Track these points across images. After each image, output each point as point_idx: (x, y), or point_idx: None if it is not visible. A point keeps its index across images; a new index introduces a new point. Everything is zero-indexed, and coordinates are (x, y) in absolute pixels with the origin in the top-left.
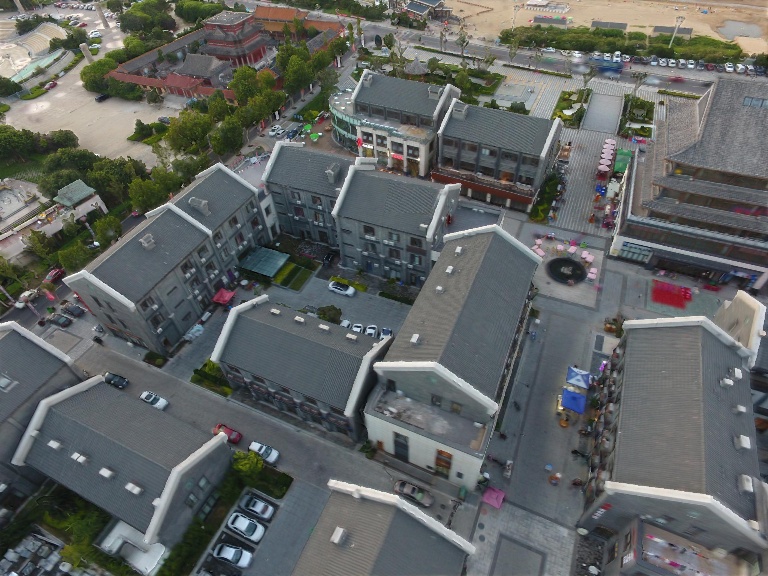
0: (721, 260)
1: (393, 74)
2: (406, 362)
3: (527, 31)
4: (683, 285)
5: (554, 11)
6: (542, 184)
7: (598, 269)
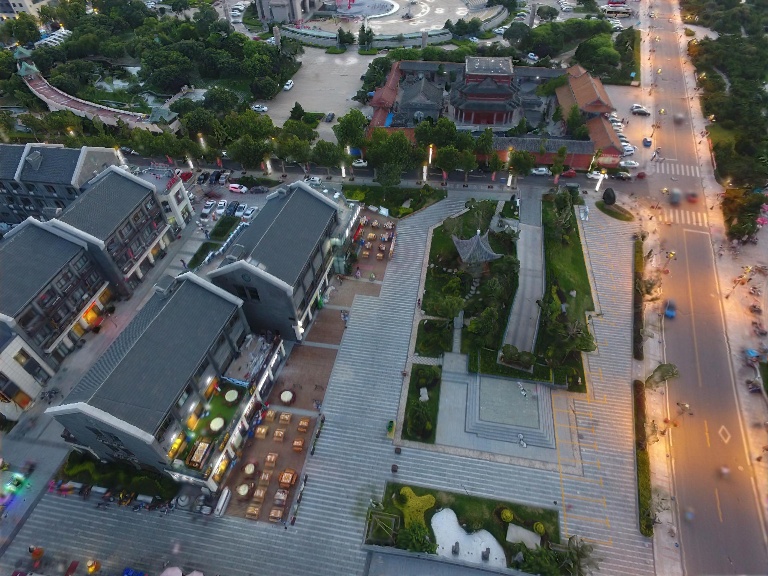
0: None
1: (499, 237)
2: None
3: None
4: None
5: None
6: None
7: None
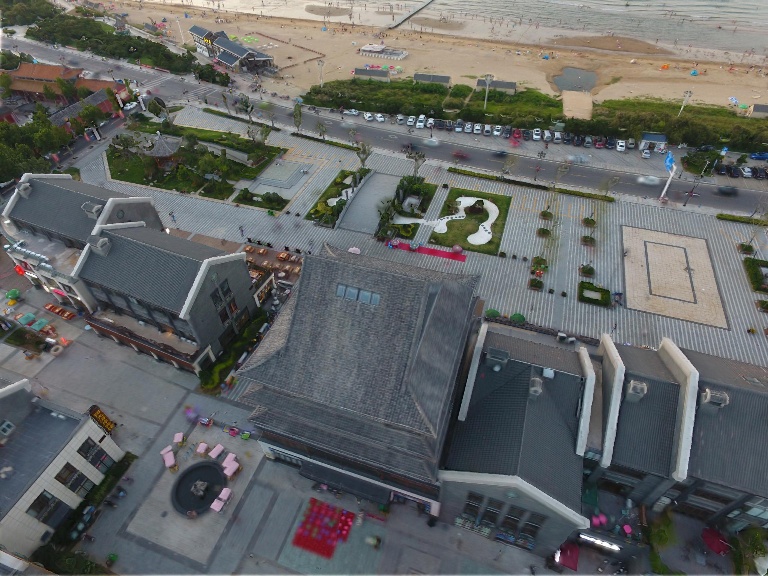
0: (378, 483)
1: None
2: None
3: (340, 87)
4: (347, 508)
5: (389, 58)
6: (233, 329)
7: (245, 481)
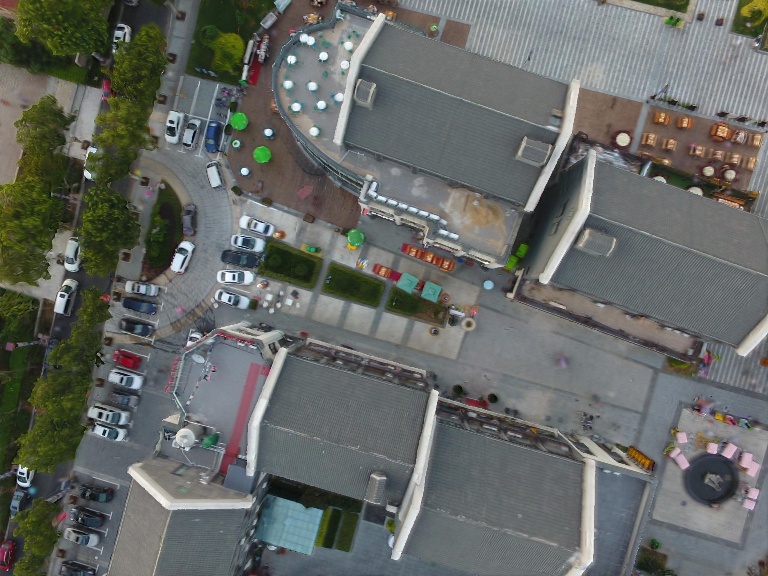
0: None
1: None
2: None
3: None
4: None
5: None
6: None
7: None
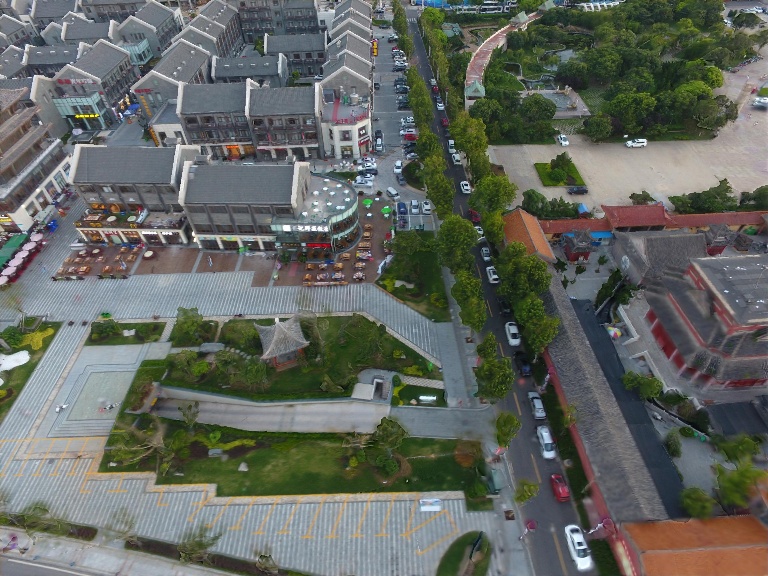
0: None
1: None
2: (194, 45)
3: None
4: None
5: None
6: None
7: None
